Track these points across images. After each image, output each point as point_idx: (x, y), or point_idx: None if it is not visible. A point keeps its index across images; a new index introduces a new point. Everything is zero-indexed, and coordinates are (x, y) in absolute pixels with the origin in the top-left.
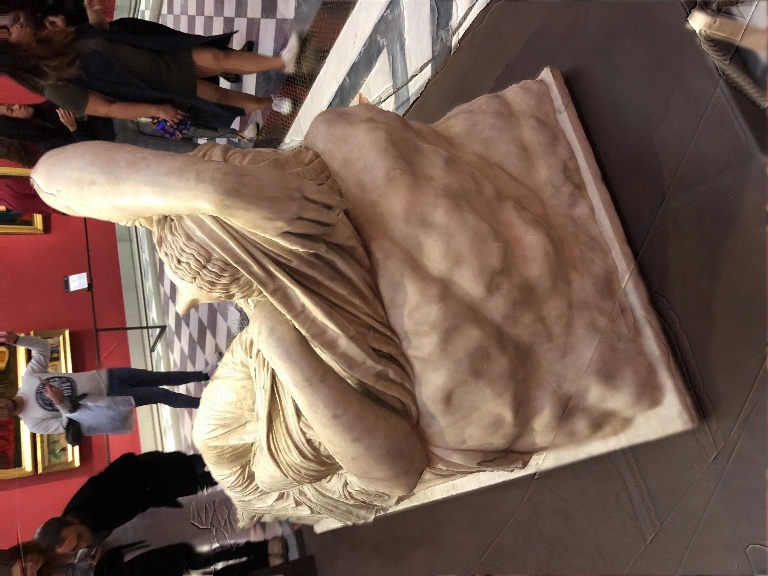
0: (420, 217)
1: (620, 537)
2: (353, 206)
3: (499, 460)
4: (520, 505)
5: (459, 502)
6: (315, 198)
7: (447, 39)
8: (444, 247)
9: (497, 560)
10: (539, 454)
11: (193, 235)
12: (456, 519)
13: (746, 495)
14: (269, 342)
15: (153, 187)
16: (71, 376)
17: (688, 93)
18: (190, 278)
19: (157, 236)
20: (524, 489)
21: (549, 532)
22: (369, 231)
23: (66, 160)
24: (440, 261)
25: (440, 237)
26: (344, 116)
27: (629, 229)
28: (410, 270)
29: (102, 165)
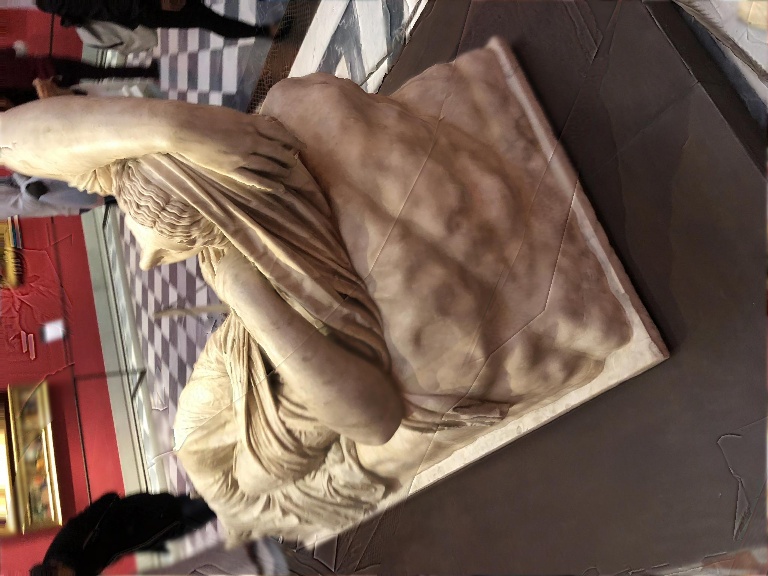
0: (376, 161)
1: (524, 164)
2: (310, 157)
3: (475, 407)
4: (506, 477)
5: (447, 488)
6: (269, 134)
7: (400, 34)
8: (402, 188)
9: (413, 215)
10: (519, 416)
11: (150, 178)
12: (445, 506)
13: (721, 419)
14: (234, 288)
15: (107, 126)
16: (21, 252)
17: (625, 40)
18: (150, 222)
19: (115, 187)
20: (509, 460)
21: (458, 171)
22: (327, 178)
23: (20, 113)
24: (399, 202)
25: (397, 179)
26: (298, 82)
27: (584, 179)
28: (370, 212)
29: (56, 111)
